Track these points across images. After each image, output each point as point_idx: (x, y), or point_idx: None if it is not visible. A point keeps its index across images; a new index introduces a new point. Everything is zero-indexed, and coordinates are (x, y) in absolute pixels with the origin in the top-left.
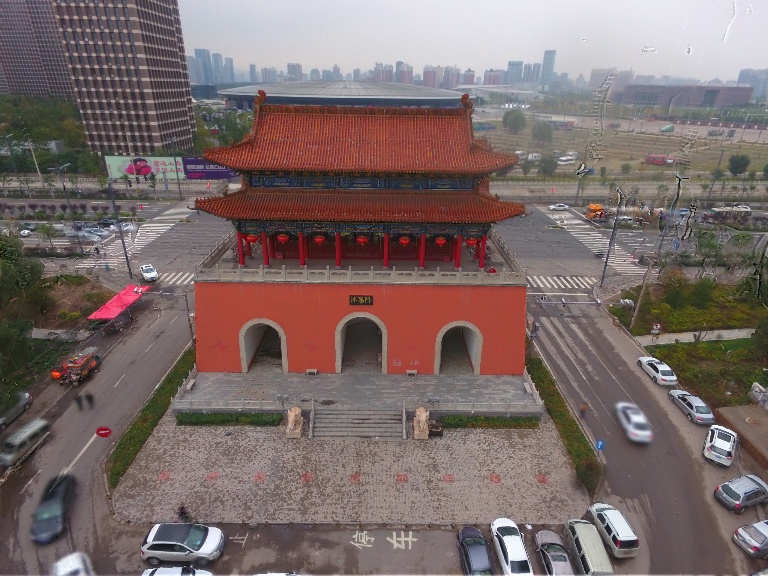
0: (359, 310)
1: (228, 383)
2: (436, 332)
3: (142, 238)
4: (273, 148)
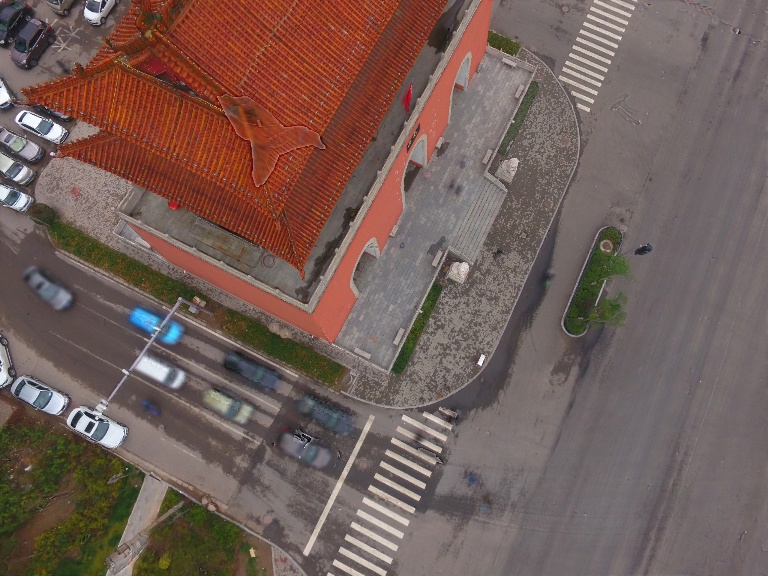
0: None
1: None
2: None
3: None
4: None
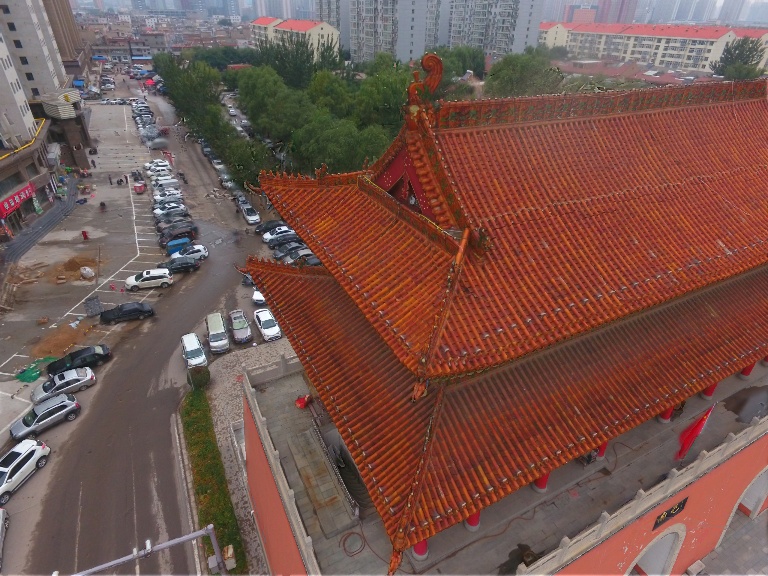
0: None
1: None
2: None
3: None
4: None
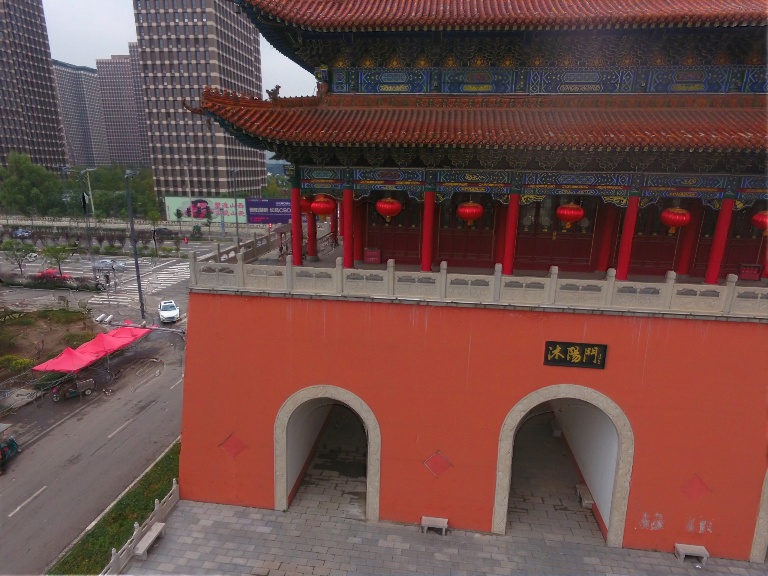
0: (566, 380)
1: (238, 539)
2: (767, 451)
3: (178, 274)
4: (384, 5)
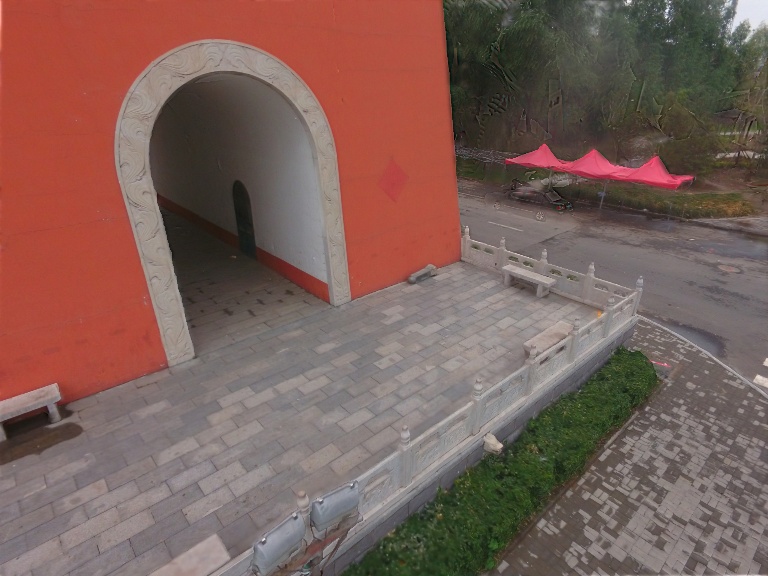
0: None
1: None
2: None
3: None
4: None
